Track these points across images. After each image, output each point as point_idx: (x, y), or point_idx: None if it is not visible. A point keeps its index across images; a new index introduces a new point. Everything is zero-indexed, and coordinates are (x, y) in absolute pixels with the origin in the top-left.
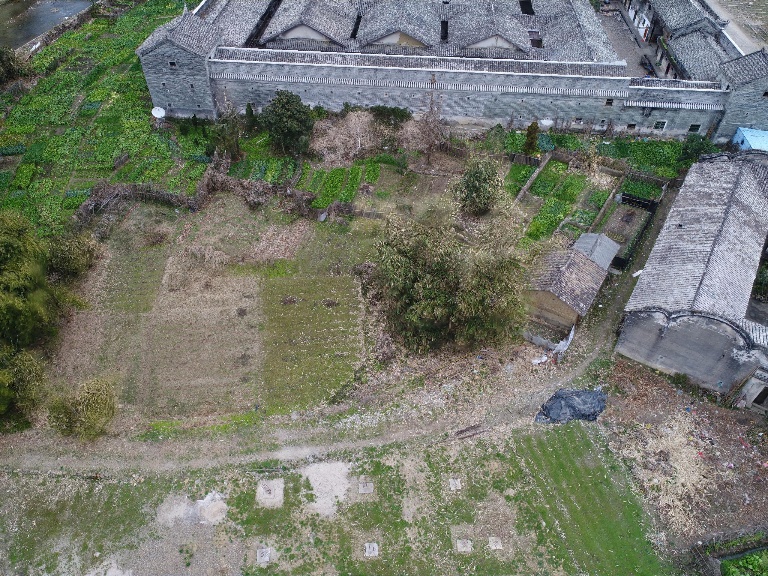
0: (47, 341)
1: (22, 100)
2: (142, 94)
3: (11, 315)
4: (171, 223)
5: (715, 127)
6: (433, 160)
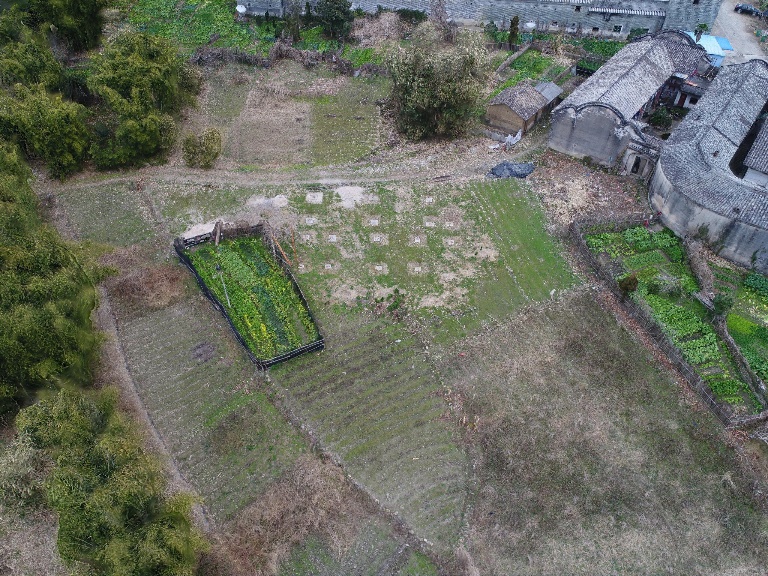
0: None
1: (139, 2)
2: (227, 1)
3: (162, 88)
4: (251, 74)
5: (659, 30)
6: (441, 47)
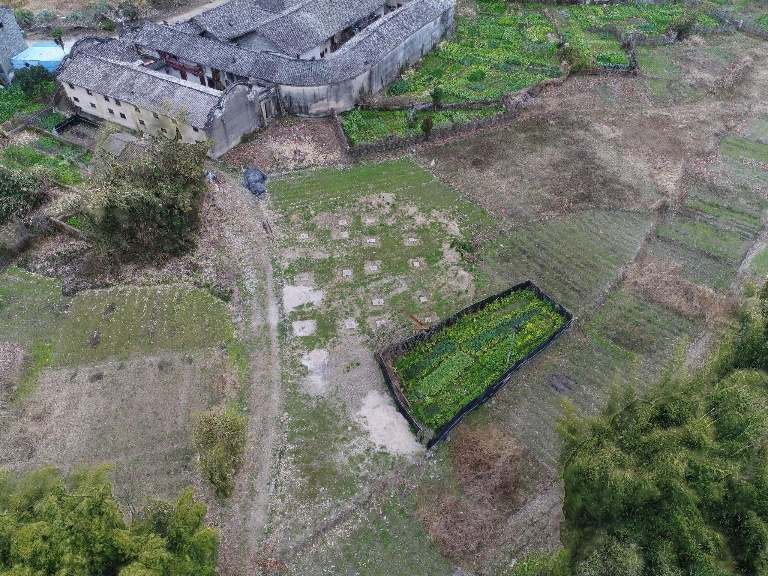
0: None
1: None
2: None
3: None
4: None
5: None
6: None
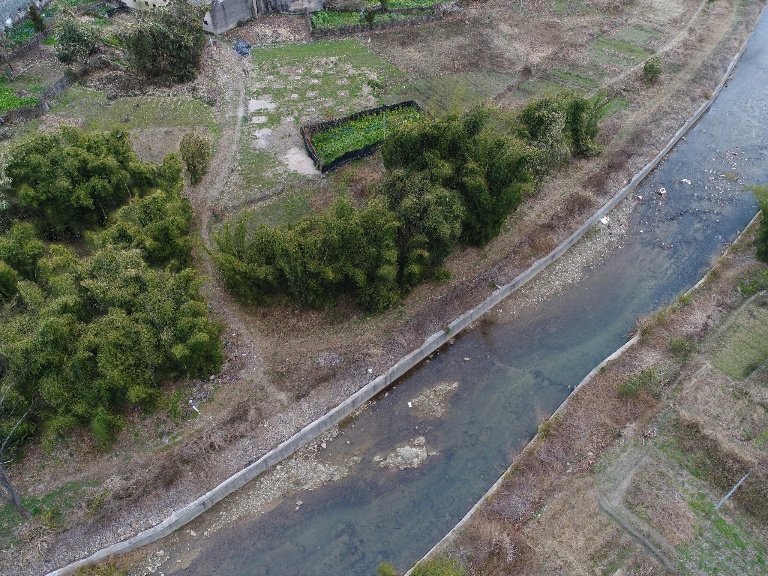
0: None
1: None
2: None
3: None
4: None
5: None
6: (9, 68)
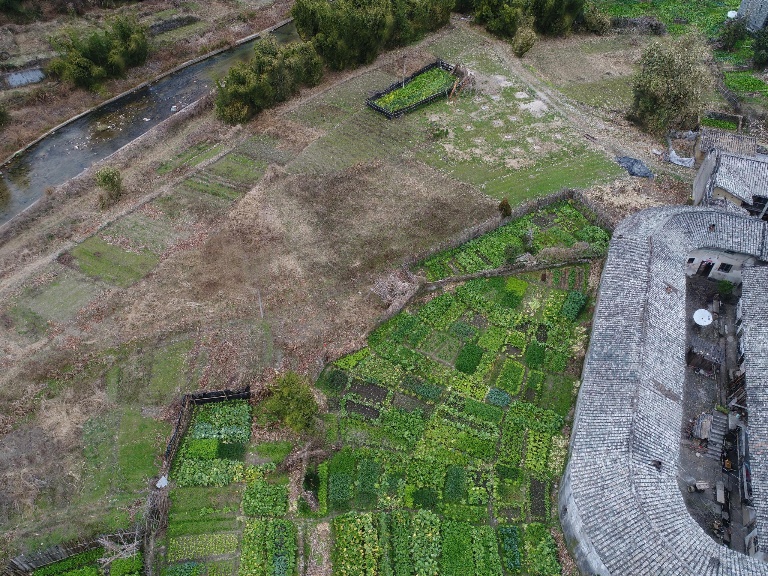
0: (551, 37)
1: None
2: None
3: (544, 0)
4: None
5: None
6: None
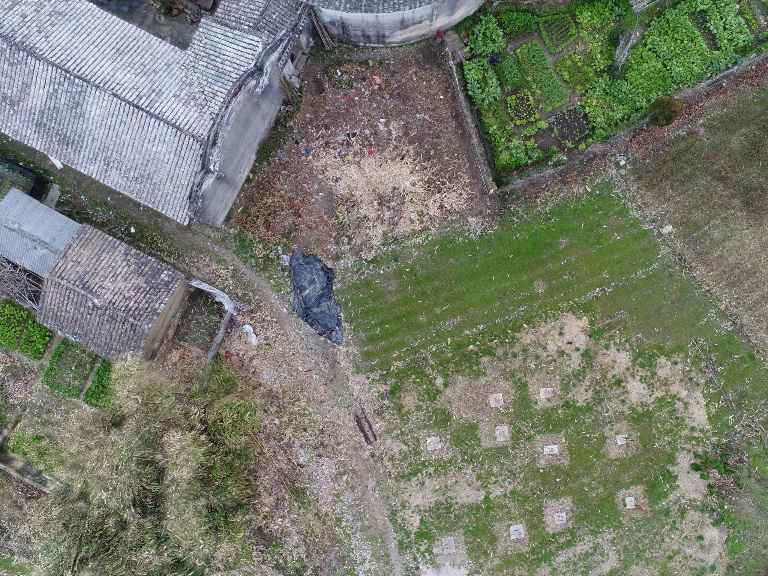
0: None
1: None
2: None
3: None
4: None
5: None
6: None
